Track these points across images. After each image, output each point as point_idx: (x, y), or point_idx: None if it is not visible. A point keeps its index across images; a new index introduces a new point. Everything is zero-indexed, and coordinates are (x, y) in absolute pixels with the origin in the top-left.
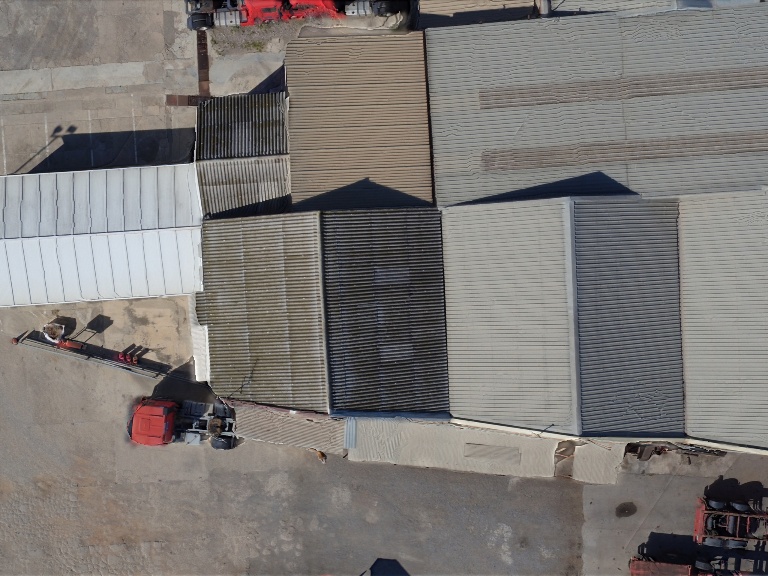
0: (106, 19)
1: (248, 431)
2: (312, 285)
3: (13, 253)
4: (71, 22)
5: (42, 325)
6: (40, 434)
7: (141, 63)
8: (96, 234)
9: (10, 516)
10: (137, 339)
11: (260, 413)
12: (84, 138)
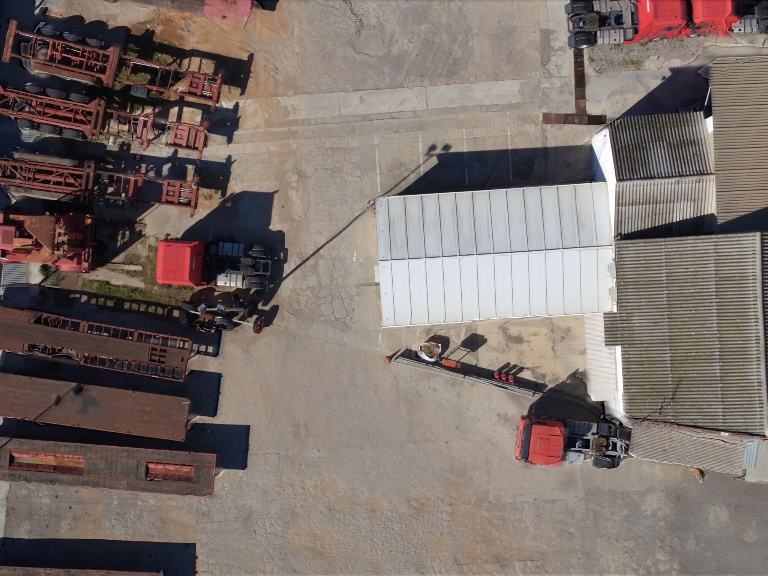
0: (482, 37)
1: (644, 451)
2: (748, 307)
3: (416, 273)
4: (446, 40)
5: (418, 344)
6: (413, 452)
7: (517, 81)
8: (499, 254)
9: (383, 534)
10: (512, 358)
11: (657, 433)
12: (459, 157)
